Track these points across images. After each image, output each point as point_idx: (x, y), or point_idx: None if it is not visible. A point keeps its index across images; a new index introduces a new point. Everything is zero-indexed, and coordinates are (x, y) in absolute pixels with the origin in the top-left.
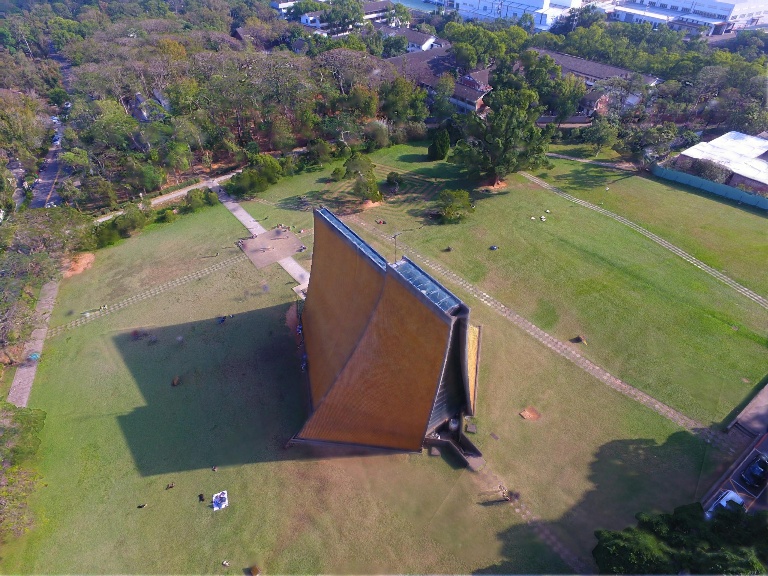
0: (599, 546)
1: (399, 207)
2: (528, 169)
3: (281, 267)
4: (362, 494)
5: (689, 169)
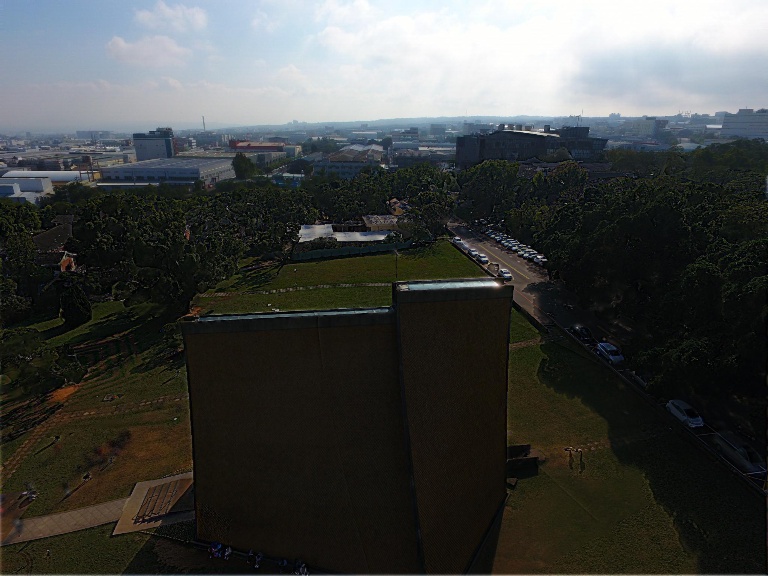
0: (670, 382)
1: (112, 375)
2: (220, 280)
3: (26, 542)
4: (550, 574)
5: (312, 249)
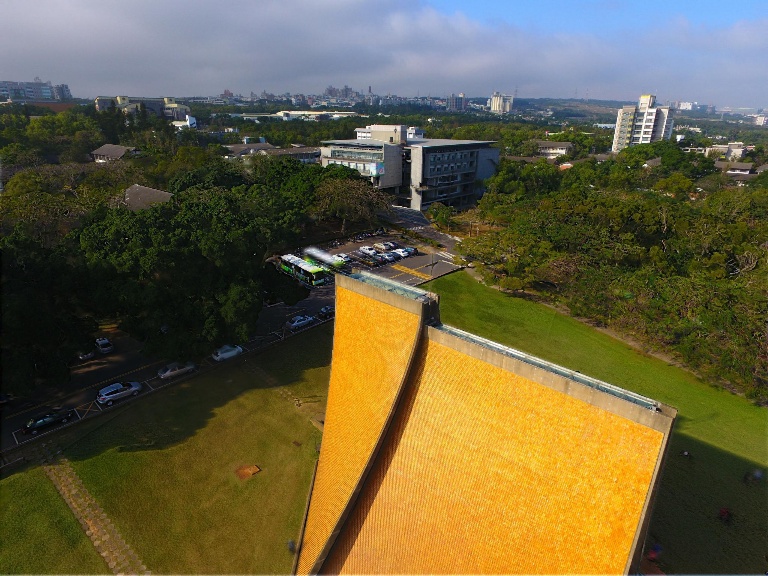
0: None
1: None
2: None
3: None
4: None
5: None
